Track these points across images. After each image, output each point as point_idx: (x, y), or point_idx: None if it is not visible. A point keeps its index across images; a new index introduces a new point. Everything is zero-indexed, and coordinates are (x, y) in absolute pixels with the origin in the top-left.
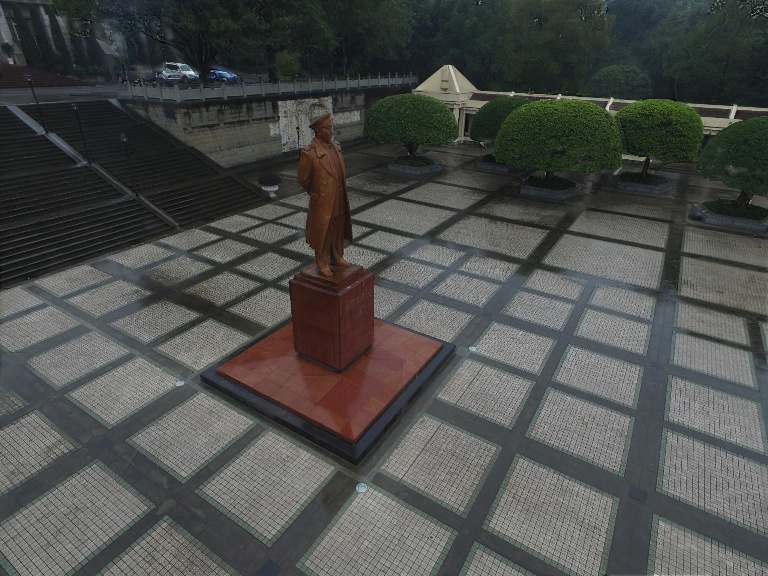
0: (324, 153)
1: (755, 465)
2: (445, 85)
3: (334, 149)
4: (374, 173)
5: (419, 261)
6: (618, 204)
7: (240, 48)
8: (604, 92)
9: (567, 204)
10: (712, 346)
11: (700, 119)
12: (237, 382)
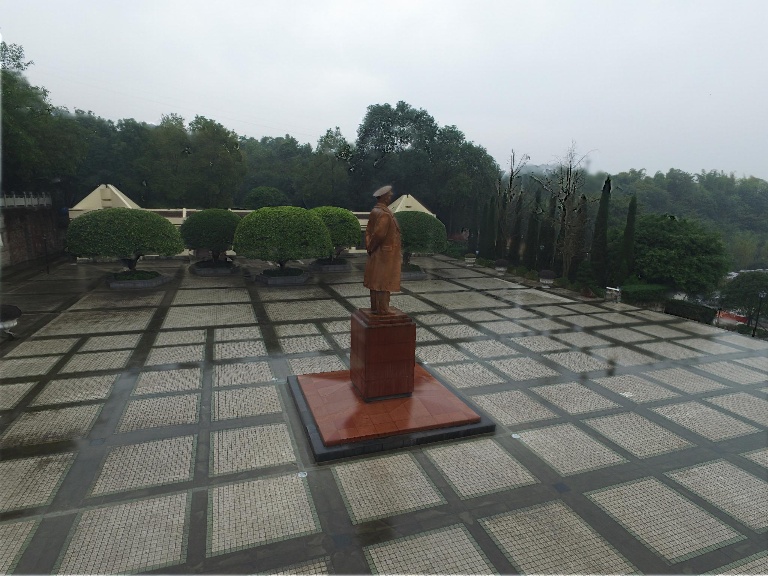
0: None
1: (576, 352)
2: (108, 204)
3: None
4: (100, 293)
5: (294, 336)
6: (340, 278)
7: None
8: (262, 206)
9: (311, 284)
10: (496, 323)
11: (356, 218)
12: (357, 439)
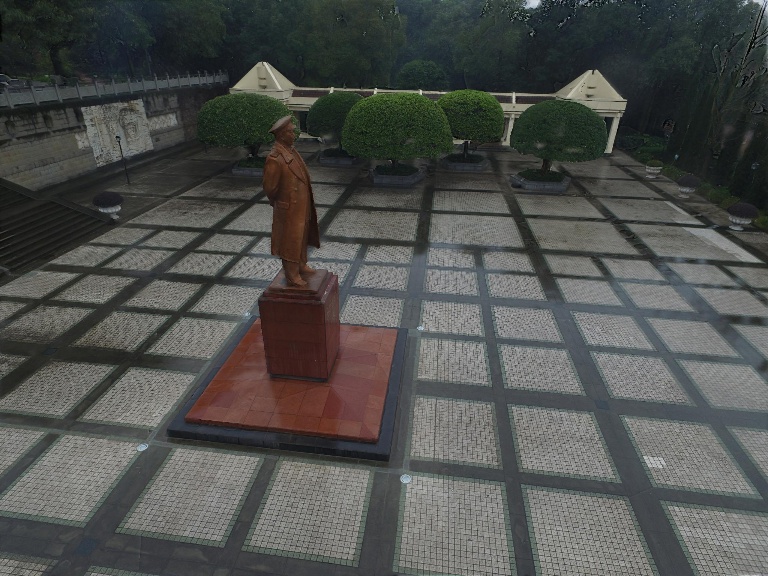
0: (291, 158)
1: (653, 359)
2: (263, 83)
3: (295, 153)
4: (220, 179)
5: (323, 260)
6: (457, 182)
7: (36, 45)
8: (412, 85)
9: (418, 187)
10: (583, 283)
11: (500, 105)
12: (218, 424)
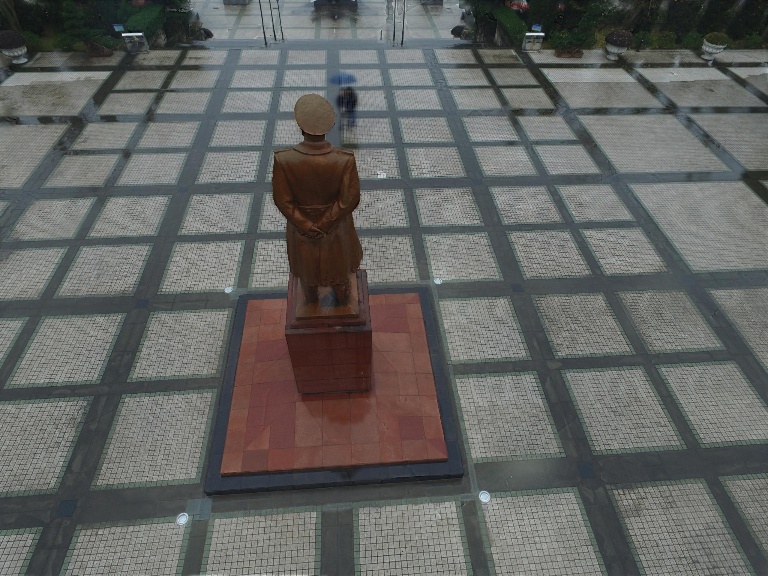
0: None
1: None
2: None
3: None
4: None
5: None
6: None
7: None
8: None
9: None
10: (133, 168)
11: None
12: None
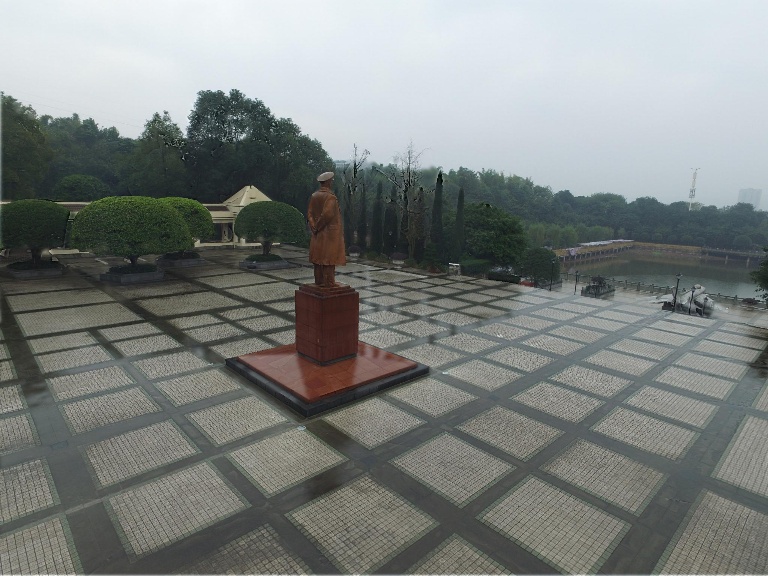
0: None
1: None
2: None
3: None
4: None
5: (198, 327)
6: (200, 272)
7: None
8: (79, 197)
9: (173, 279)
10: (378, 298)
11: None
12: (333, 394)
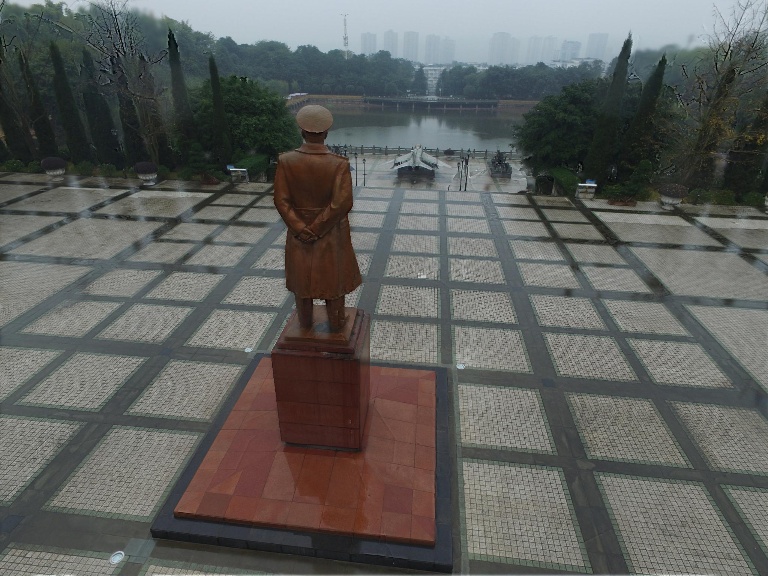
0: None
1: None
2: None
3: None
4: None
5: None
6: None
7: None
8: None
9: None
10: (203, 254)
11: None
12: None
